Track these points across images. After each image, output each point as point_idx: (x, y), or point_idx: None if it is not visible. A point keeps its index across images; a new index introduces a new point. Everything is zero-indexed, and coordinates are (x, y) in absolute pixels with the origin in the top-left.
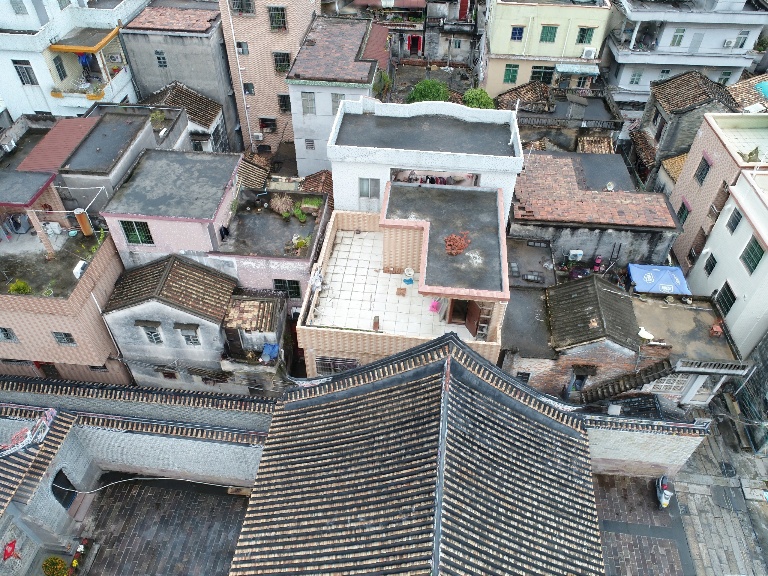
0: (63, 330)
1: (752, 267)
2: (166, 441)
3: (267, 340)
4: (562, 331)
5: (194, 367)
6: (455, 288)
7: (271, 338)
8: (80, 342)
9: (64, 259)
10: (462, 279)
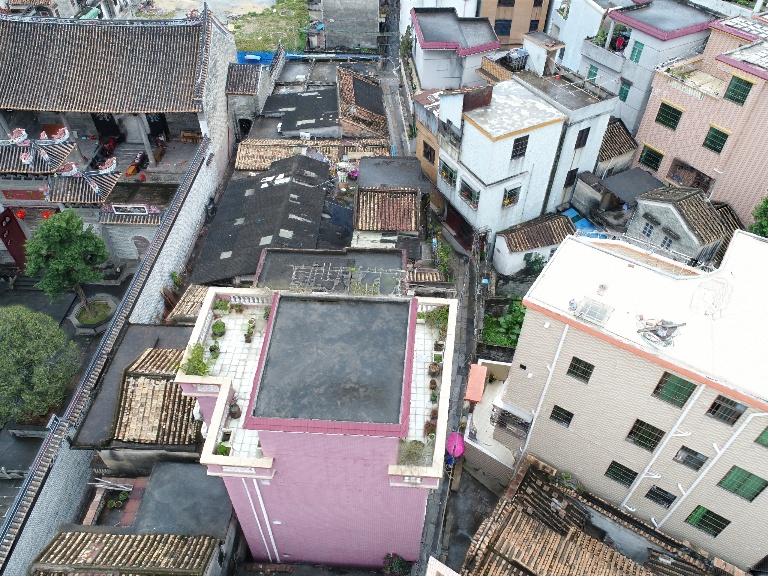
0: None
1: None
2: None
3: None
4: None
5: None
6: None
7: None
8: None
9: None
10: None
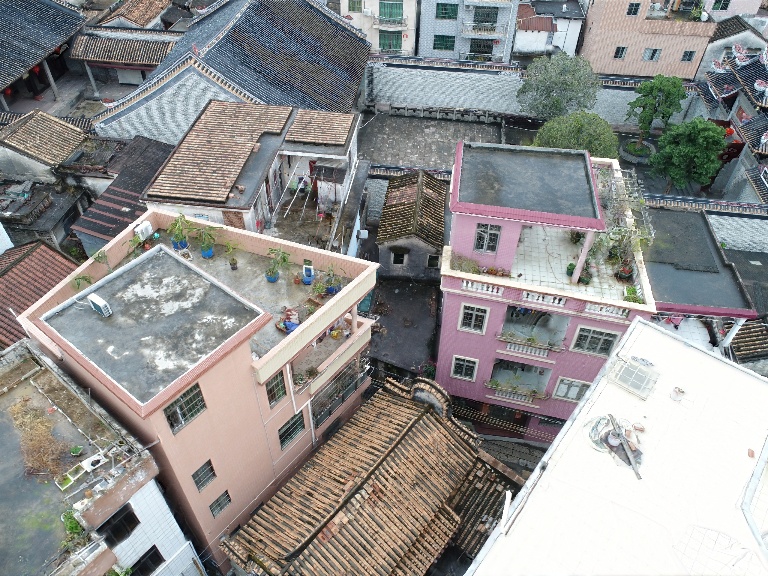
0: (693, 49)
1: None
2: None
3: None
4: None
5: None
6: None
7: None
8: (695, 59)
9: (676, 18)
10: None
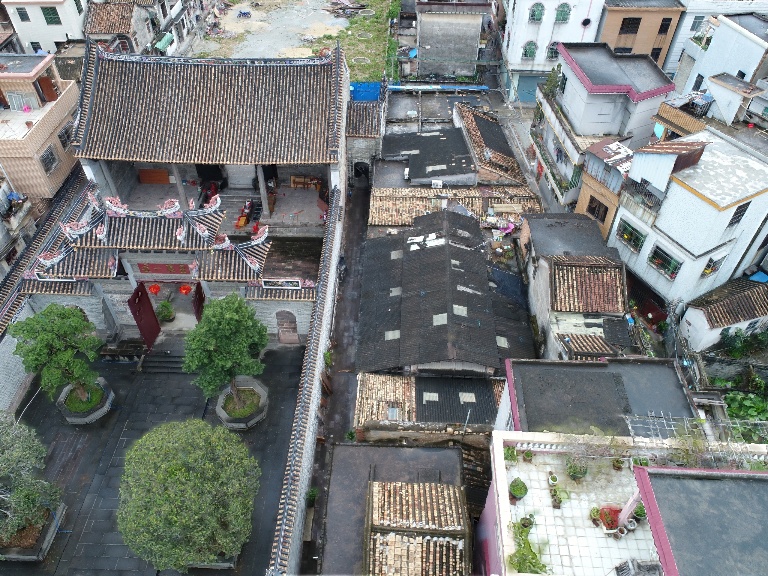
0: None
1: (58, 20)
2: None
3: (6, 193)
4: (69, 76)
5: (2, 249)
6: (38, 65)
7: (6, 189)
8: None
9: None
10: (30, 66)
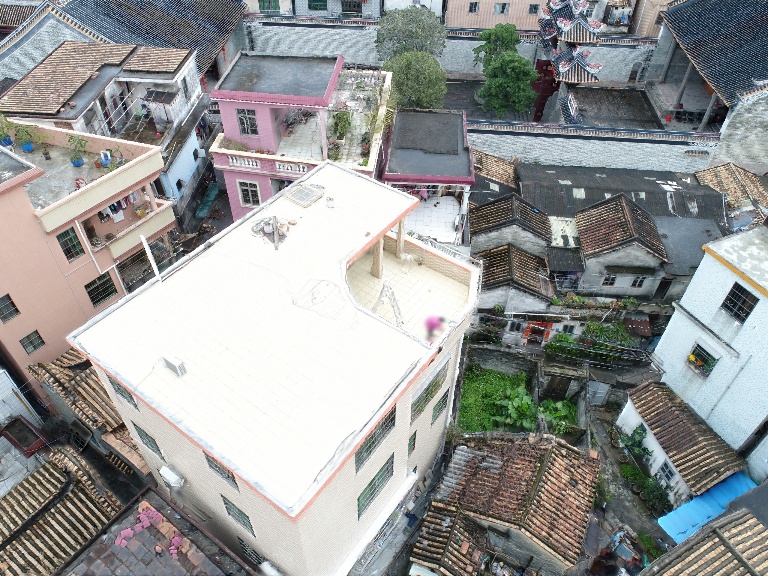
0: (537, 2)
1: None
2: (592, 51)
3: (623, 15)
4: None
5: None
6: None
7: (626, 13)
8: (540, 11)
9: None
10: None
